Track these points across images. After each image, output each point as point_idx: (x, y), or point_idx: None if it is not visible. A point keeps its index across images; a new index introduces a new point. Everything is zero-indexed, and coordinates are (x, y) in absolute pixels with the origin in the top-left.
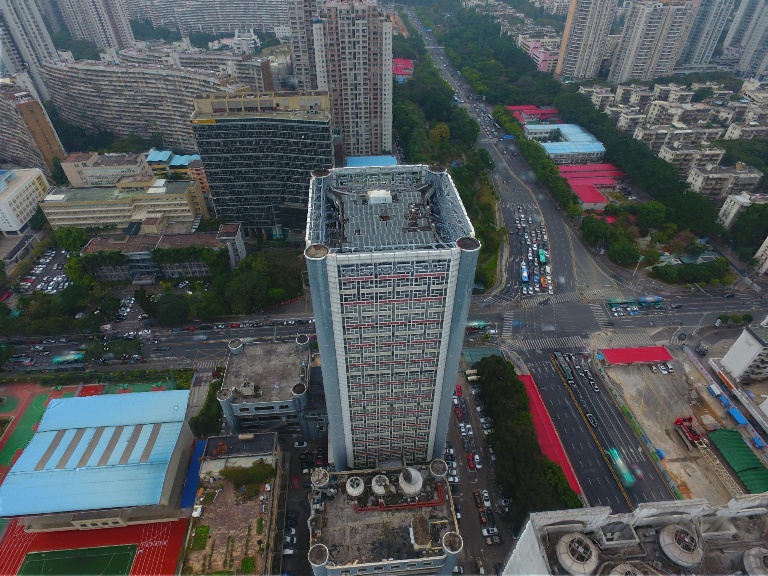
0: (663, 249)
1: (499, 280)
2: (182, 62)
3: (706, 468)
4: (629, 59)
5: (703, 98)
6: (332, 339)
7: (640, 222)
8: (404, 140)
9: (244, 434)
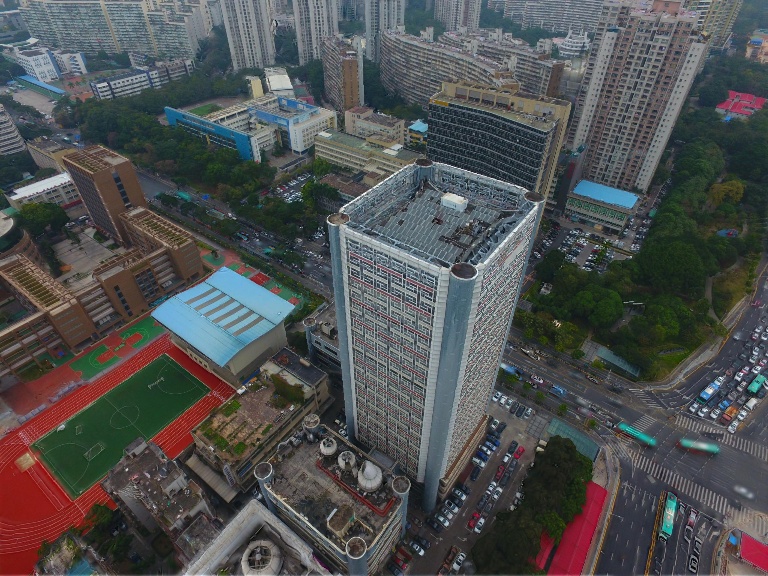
0: None
1: (668, 379)
2: (479, 50)
3: None
4: None
5: None
6: (343, 305)
7: None
8: (674, 185)
9: (305, 360)
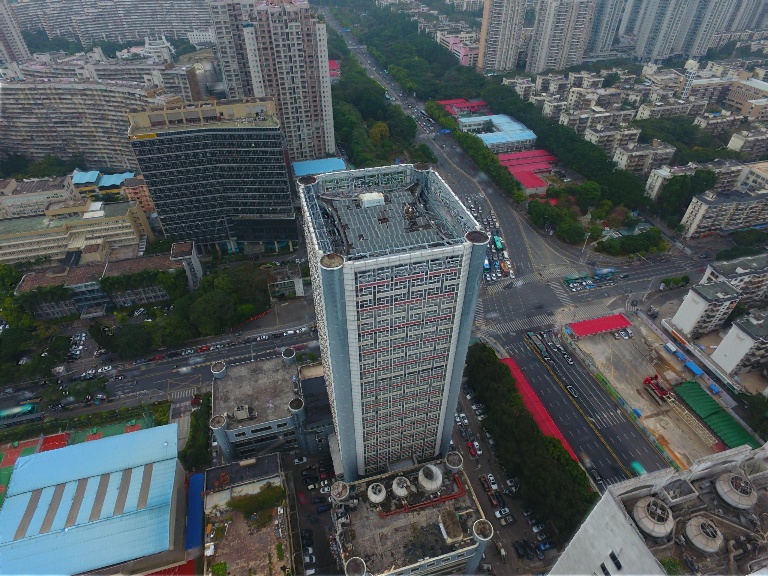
0: (603, 225)
1: None
2: (99, 74)
3: (677, 419)
4: (543, 50)
5: (612, 83)
6: (347, 348)
7: (580, 202)
8: (345, 141)
9: (245, 460)
